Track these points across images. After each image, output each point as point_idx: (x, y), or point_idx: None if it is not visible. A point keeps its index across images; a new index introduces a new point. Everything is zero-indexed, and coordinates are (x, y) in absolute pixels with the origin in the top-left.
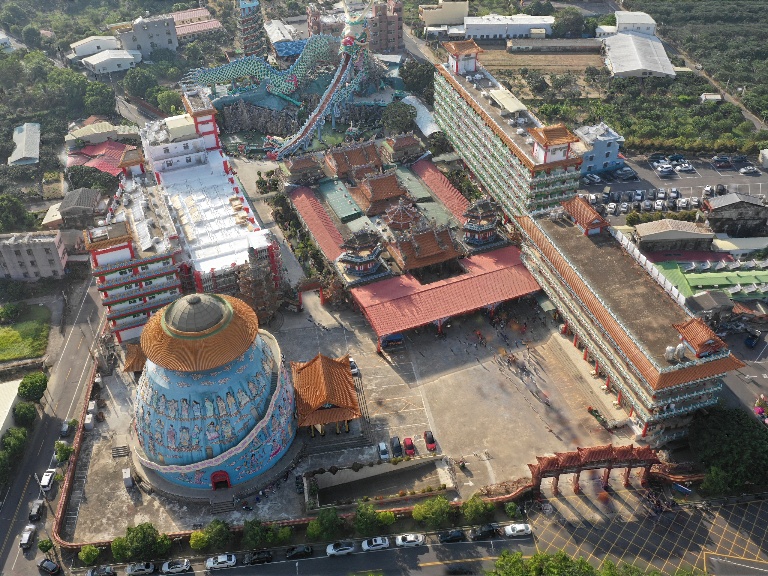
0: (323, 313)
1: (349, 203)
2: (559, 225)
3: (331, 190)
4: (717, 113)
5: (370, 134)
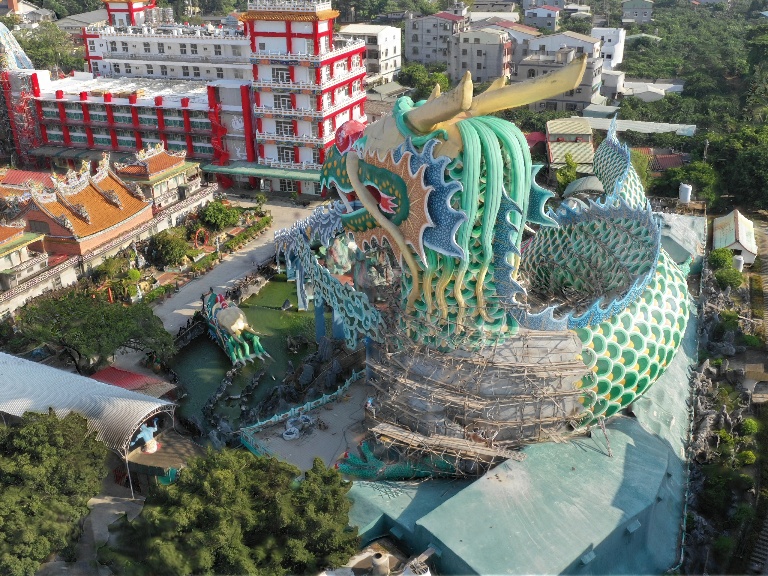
0: None
1: None
2: None
3: None
4: None
5: (207, 372)
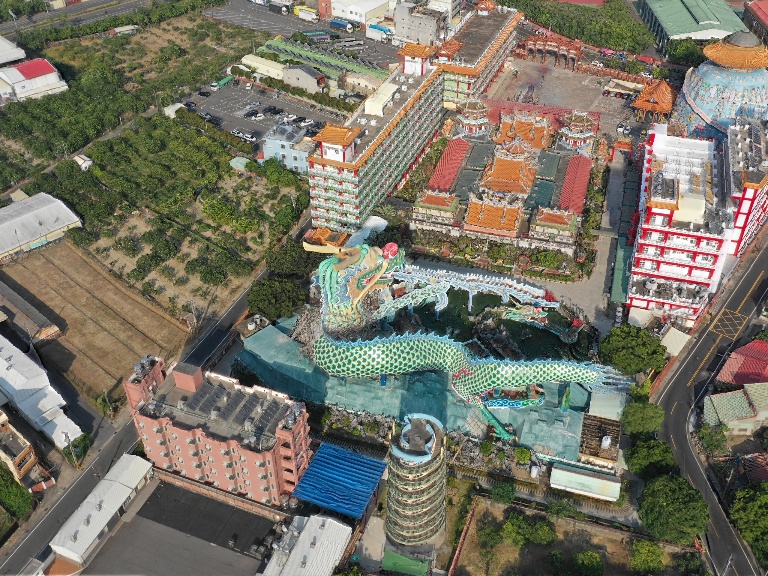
0: (615, 158)
1: (538, 188)
2: (465, 59)
3: (541, 206)
4: (124, 145)
5: None
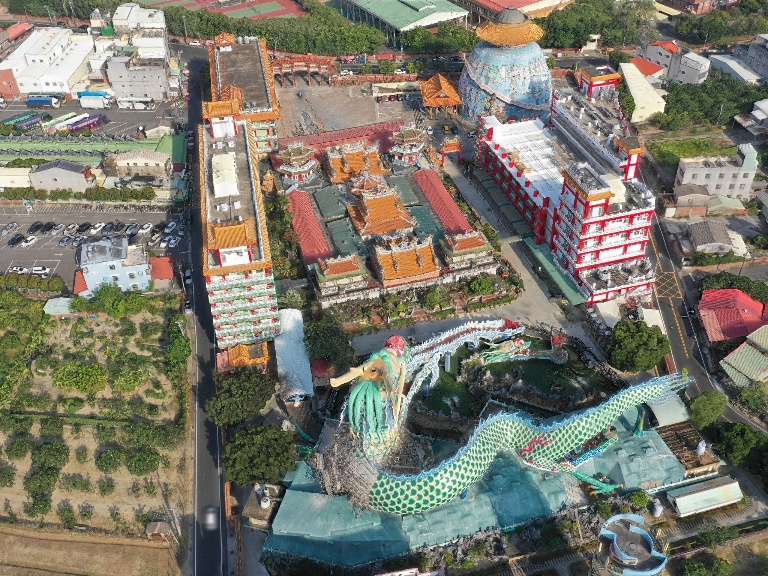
0: None
1: (415, 217)
2: None
3: None
4: None
5: None
